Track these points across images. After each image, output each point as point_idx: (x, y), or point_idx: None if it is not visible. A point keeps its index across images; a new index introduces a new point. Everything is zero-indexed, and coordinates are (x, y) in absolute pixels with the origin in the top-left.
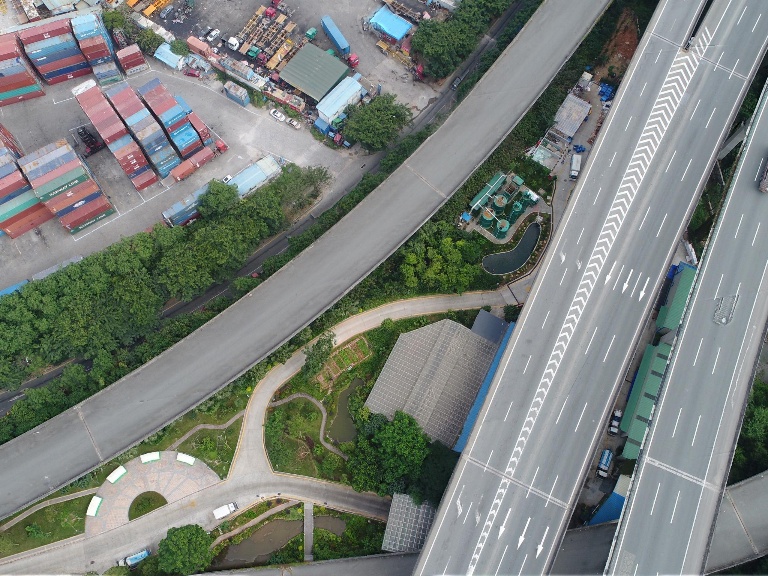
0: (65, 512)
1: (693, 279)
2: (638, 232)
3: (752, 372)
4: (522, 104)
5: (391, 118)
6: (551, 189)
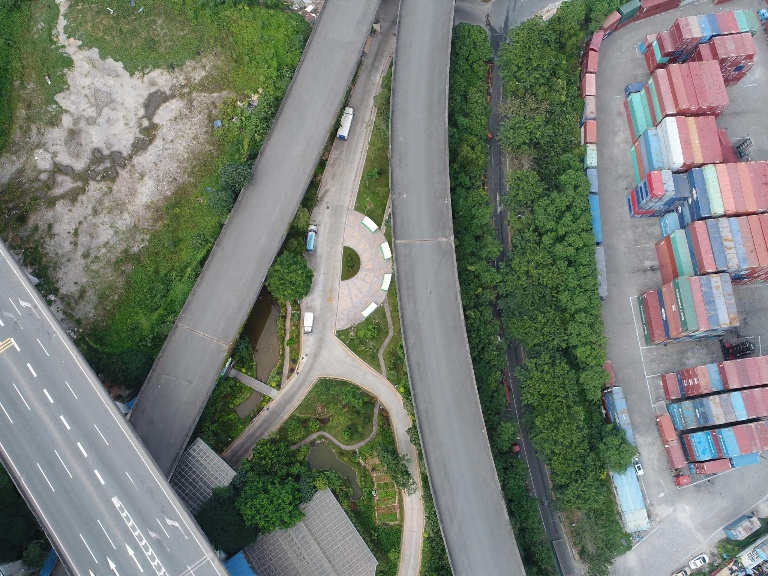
0: (379, 201)
1: None
2: None
3: None
4: None
5: None
6: None
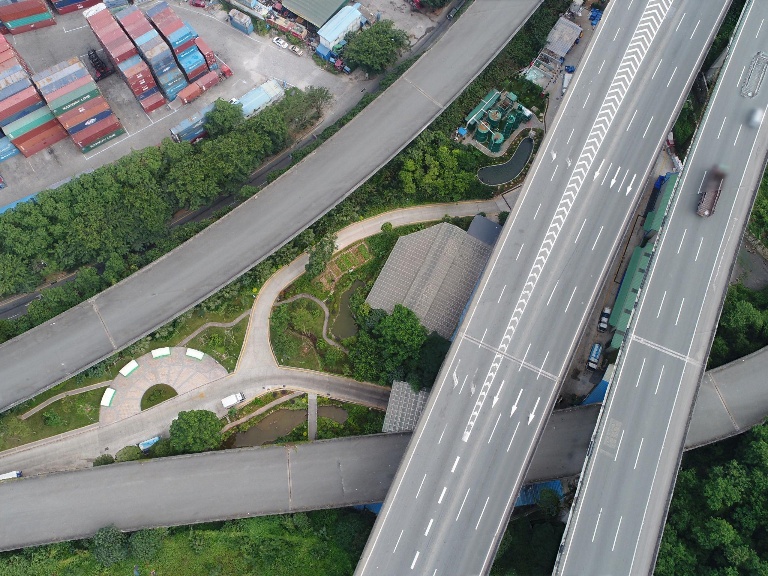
0: (80, 403)
1: (678, 176)
2: (625, 133)
3: (733, 259)
4: (515, 21)
5: (390, 41)
6: (544, 106)
